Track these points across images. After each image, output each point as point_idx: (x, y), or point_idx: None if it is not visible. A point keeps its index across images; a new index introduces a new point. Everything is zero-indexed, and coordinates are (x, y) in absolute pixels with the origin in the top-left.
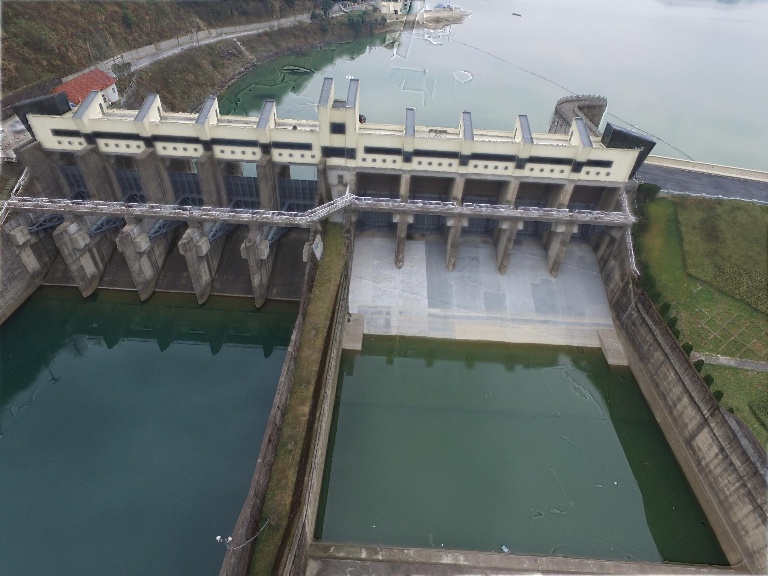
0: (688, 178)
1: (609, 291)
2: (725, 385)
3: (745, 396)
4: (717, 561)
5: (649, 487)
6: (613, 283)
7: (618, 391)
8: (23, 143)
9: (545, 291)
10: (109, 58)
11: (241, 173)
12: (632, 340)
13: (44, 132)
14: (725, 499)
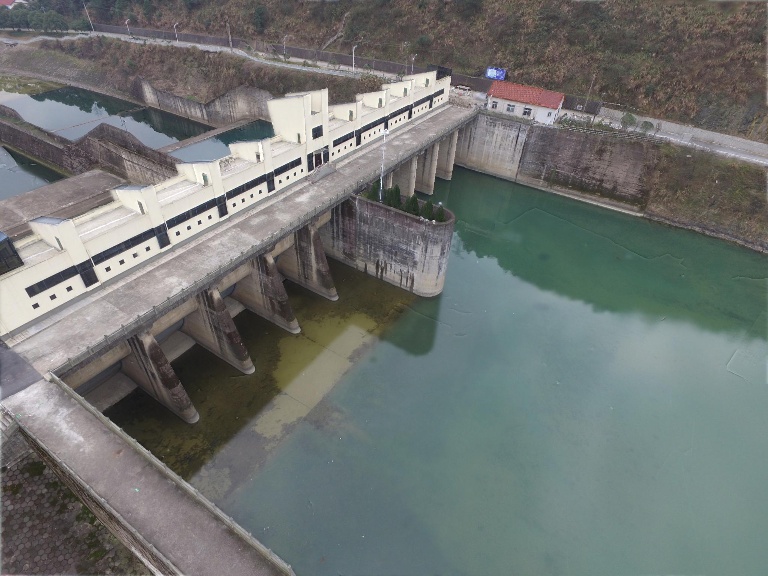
0: None
1: None
2: None
3: None
4: None
5: None
6: None
7: None
8: None
9: None
10: (715, 131)
11: (407, 179)
12: None
13: None
14: None
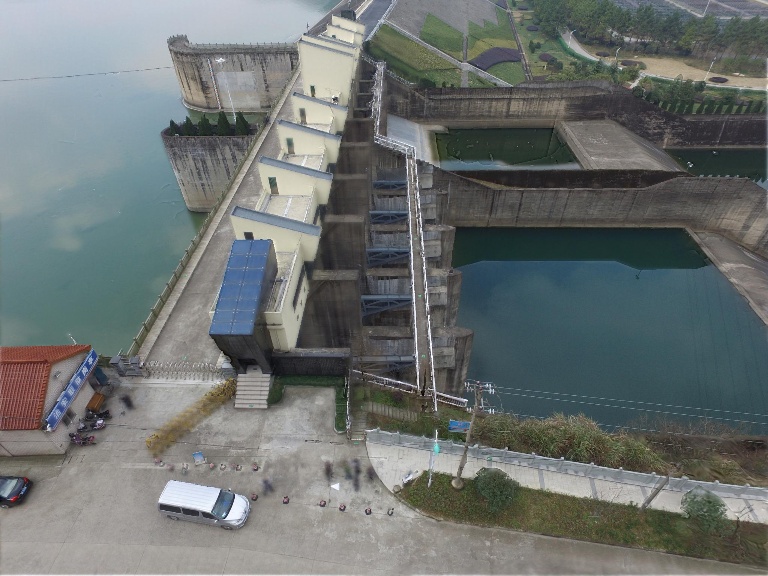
0: None
1: (400, 113)
2: None
3: None
4: (548, 135)
5: (500, 157)
6: (400, 106)
7: (449, 148)
8: (318, 354)
9: (398, 133)
10: None
11: None
12: (440, 116)
13: (290, 321)
14: (537, 112)
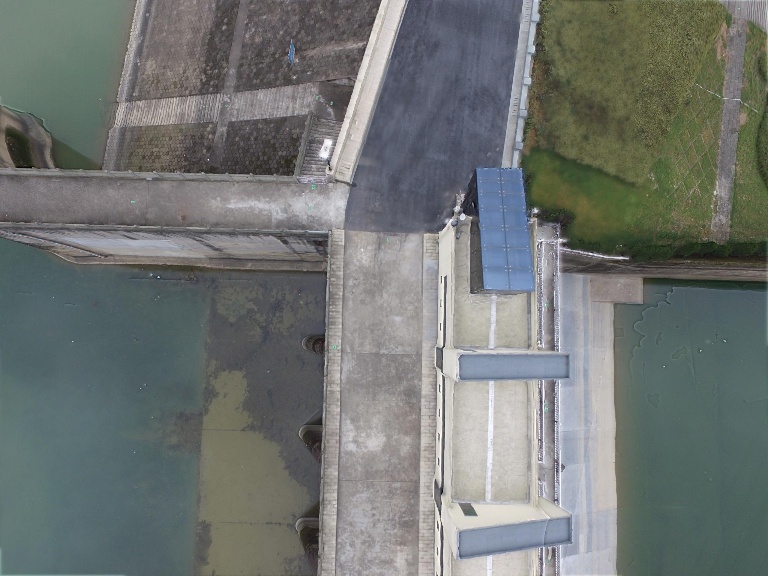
0: (435, 66)
1: None
2: (760, 212)
3: (764, 193)
4: None
5: None
6: None
7: None
8: None
9: None
10: None
11: None
12: None
13: None
14: None
